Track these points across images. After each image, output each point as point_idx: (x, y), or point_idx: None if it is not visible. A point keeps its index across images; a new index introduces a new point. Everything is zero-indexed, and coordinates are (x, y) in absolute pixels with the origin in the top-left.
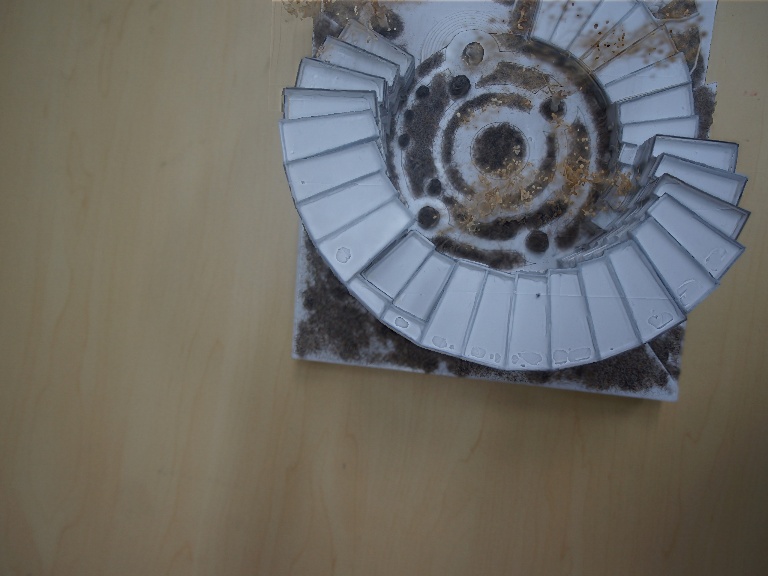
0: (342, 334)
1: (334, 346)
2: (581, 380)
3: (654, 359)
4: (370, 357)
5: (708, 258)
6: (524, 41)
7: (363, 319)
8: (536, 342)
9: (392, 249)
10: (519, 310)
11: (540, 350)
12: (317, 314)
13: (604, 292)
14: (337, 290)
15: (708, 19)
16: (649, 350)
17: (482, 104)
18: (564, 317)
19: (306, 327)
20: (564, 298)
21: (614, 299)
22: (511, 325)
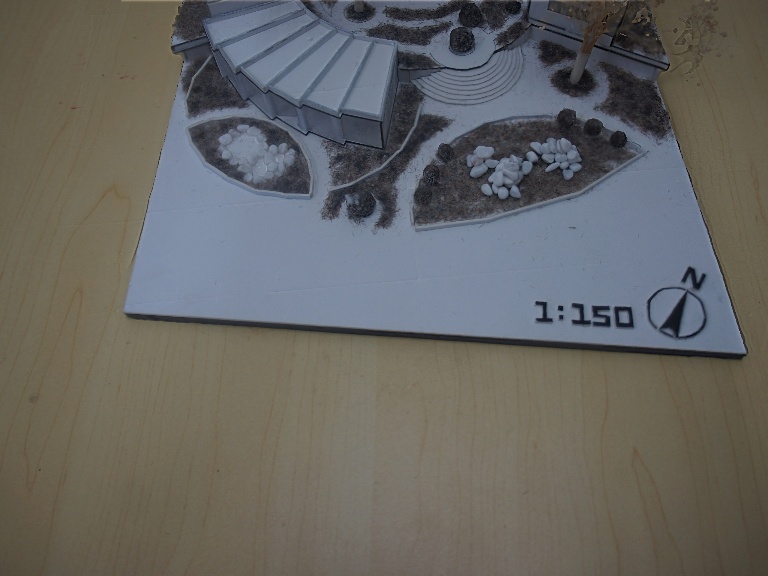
0: None
1: None
2: None
3: None
4: None
5: None
6: (403, 59)
7: None
8: None
9: None
10: None
11: None
12: None
13: None
14: None
15: (175, 128)
16: None
17: (442, 8)
18: None
19: None
20: None
21: None
22: None
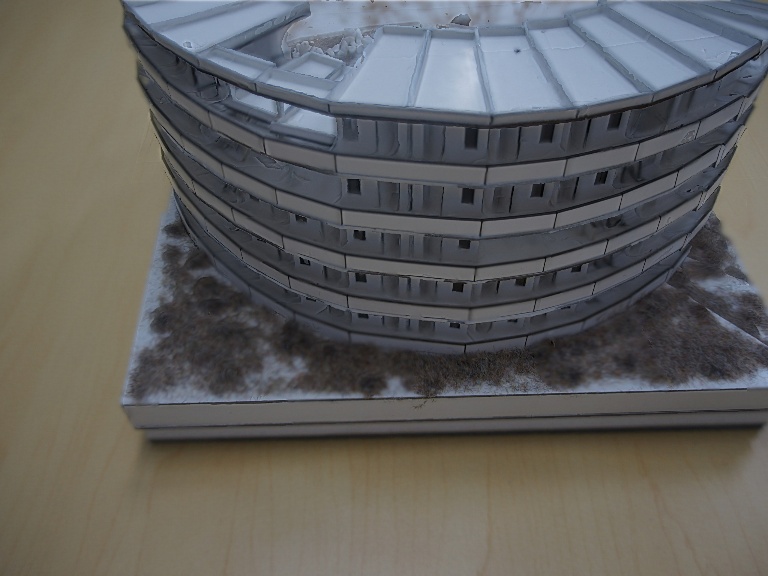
0: (214, 356)
1: (200, 377)
2: (637, 375)
3: (738, 332)
4: (264, 385)
5: (746, 110)
6: None
7: (251, 334)
8: (535, 92)
9: (278, 68)
10: (492, 66)
11: (545, 99)
12: (172, 334)
13: (618, 40)
14: (208, 300)
15: None
16: (724, 322)
17: None
18: (569, 67)
19: (151, 355)
20: (559, 50)
21: (637, 44)
22: (485, 73)
